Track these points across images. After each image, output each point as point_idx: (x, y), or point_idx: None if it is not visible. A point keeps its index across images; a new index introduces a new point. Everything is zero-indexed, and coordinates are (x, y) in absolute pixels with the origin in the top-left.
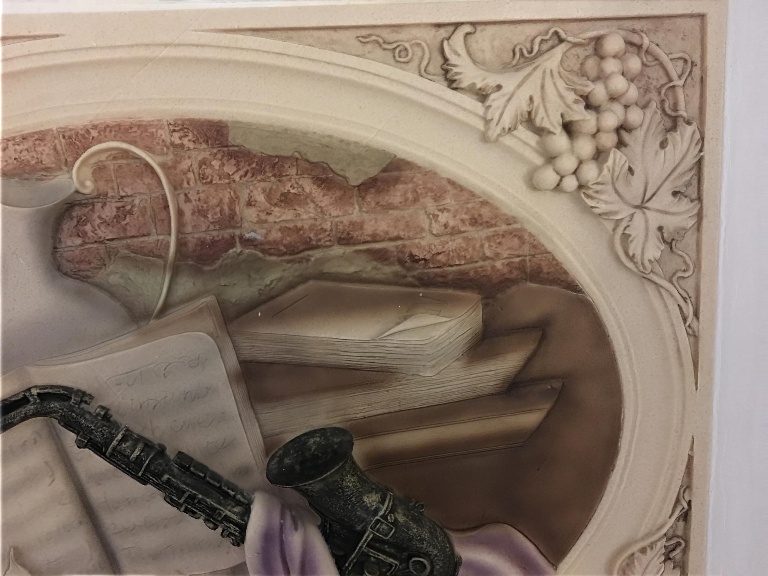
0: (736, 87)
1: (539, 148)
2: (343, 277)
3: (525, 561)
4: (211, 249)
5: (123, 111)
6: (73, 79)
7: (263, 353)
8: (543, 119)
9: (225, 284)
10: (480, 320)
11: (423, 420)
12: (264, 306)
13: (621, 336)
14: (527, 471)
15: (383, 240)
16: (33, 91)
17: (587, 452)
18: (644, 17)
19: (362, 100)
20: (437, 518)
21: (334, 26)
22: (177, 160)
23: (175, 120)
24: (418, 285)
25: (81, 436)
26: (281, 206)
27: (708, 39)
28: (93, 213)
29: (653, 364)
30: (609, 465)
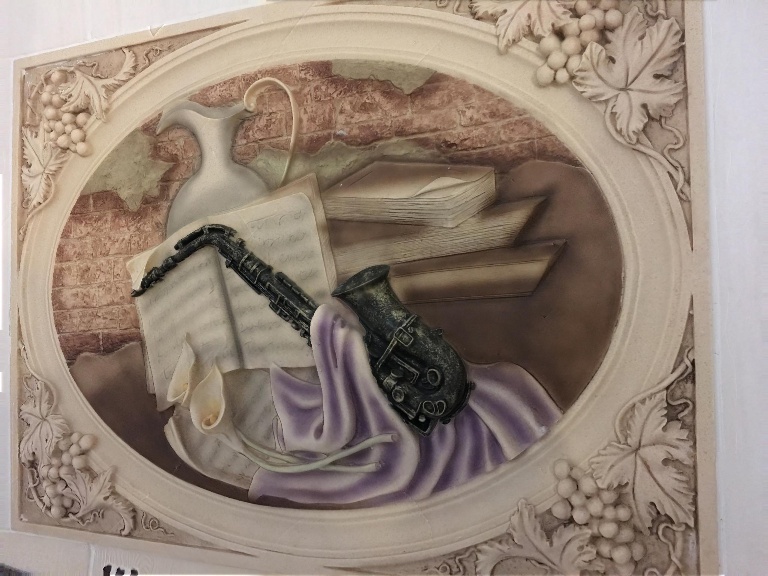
0: None
1: (539, 52)
2: (397, 158)
3: (536, 403)
4: (316, 143)
5: (275, 61)
6: (252, 46)
7: (342, 213)
8: (538, 29)
9: (322, 165)
10: (493, 187)
11: (447, 264)
12: (345, 180)
13: (619, 203)
14: (533, 316)
15: (426, 131)
16: (232, 56)
17: (591, 306)
18: None
19: (416, 37)
20: (455, 346)
21: None
22: (302, 88)
23: (303, 63)
24: (449, 163)
25: (228, 258)
26: (360, 112)
27: None
28: (254, 124)
29: (652, 229)
30: (612, 320)
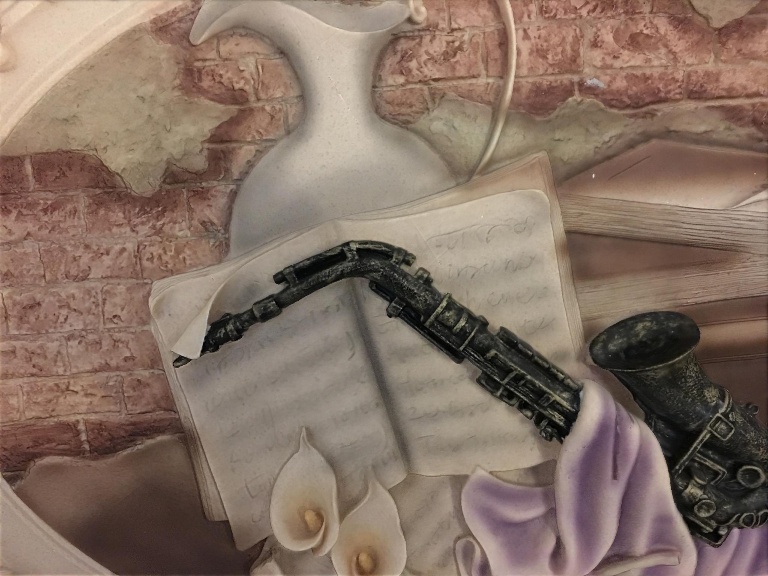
0: None
1: None
2: (691, 137)
3: None
4: (546, 97)
5: None
6: None
7: (591, 222)
8: None
9: (559, 138)
10: None
11: (764, 310)
12: (598, 167)
13: None
14: None
15: (739, 96)
16: None
17: None
18: None
19: None
20: (765, 424)
21: None
22: None
23: None
24: None
25: (396, 302)
26: (630, 49)
27: None
28: (420, 47)
29: None
30: None
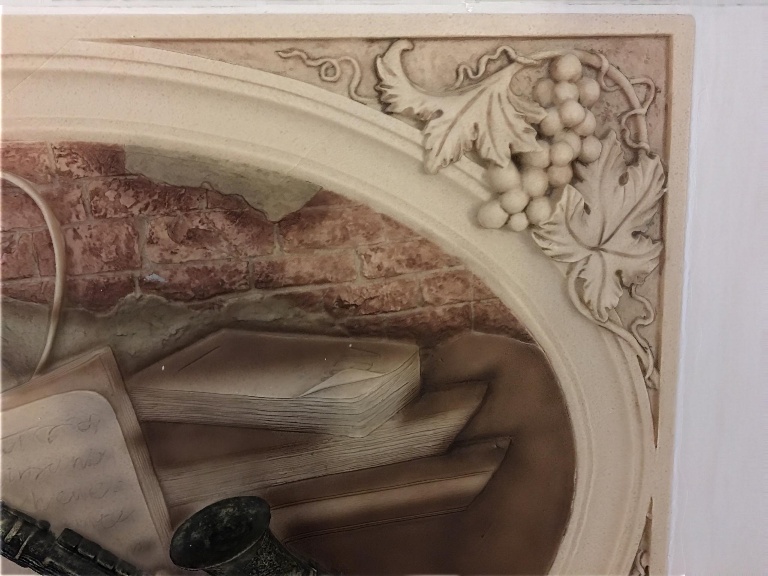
0: (703, 117)
1: (485, 182)
2: (261, 325)
3: None
4: (105, 293)
5: None
6: None
7: (168, 412)
8: (489, 150)
9: (122, 334)
10: (418, 374)
11: (352, 486)
12: (169, 358)
13: (575, 389)
14: (470, 538)
15: (307, 283)
16: None
17: (536, 516)
18: (604, 36)
19: (283, 124)
20: None
21: (249, 38)
22: (64, 190)
23: (61, 143)
24: (347, 334)
25: None
26: (188, 244)
27: (674, 63)
28: None
29: (609, 419)
30: (560, 529)
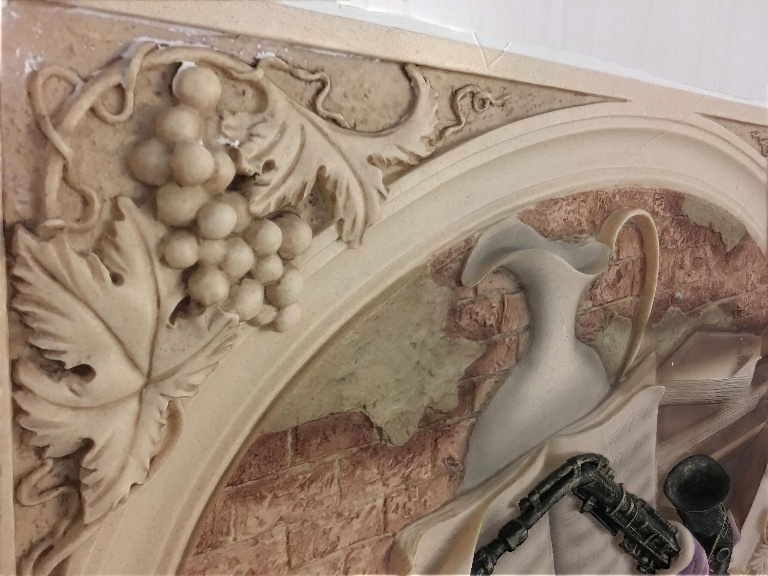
0: None
1: None
2: None
3: None
4: (657, 308)
5: (636, 178)
6: (613, 142)
7: (666, 398)
8: None
9: (661, 339)
10: None
11: (728, 438)
12: (674, 356)
13: None
14: (749, 465)
15: None
16: (586, 150)
17: (765, 445)
18: None
19: (739, 182)
20: None
21: None
22: None
23: (659, 190)
24: (737, 331)
25: (592, 500)
26: (693, 269)
27: None
28: (602, 276)
29: None
30: None
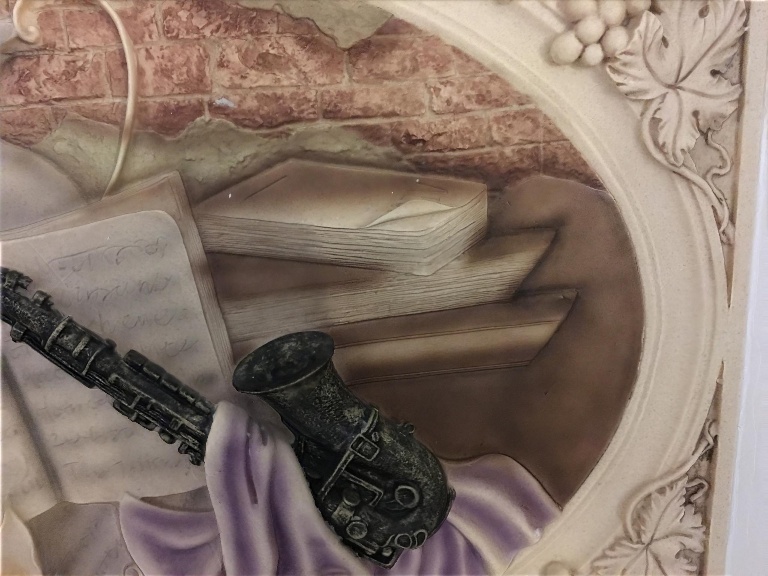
0: None
1: (559, 11)
2: (328, 157)
3: (527, 500)
4: (175, 116)
5: None
6: None
7: (233, 242)
8: None
9: (191, 158)
10: (485, 214)
11: (416, 328)
12: (236, 187)
13: (645, 242)
14: (533, 394)
15: (376, 115)
16: None
17: (602, 376)
18: None
19: None
20: (429, 443)
21: None
22: (138, 8)
23: None
24: (415, 170)
25: (16, 326)
26: (258, 69)
27: None
28: (38, 67)
29: (680, 277)
30: (626, 392)
